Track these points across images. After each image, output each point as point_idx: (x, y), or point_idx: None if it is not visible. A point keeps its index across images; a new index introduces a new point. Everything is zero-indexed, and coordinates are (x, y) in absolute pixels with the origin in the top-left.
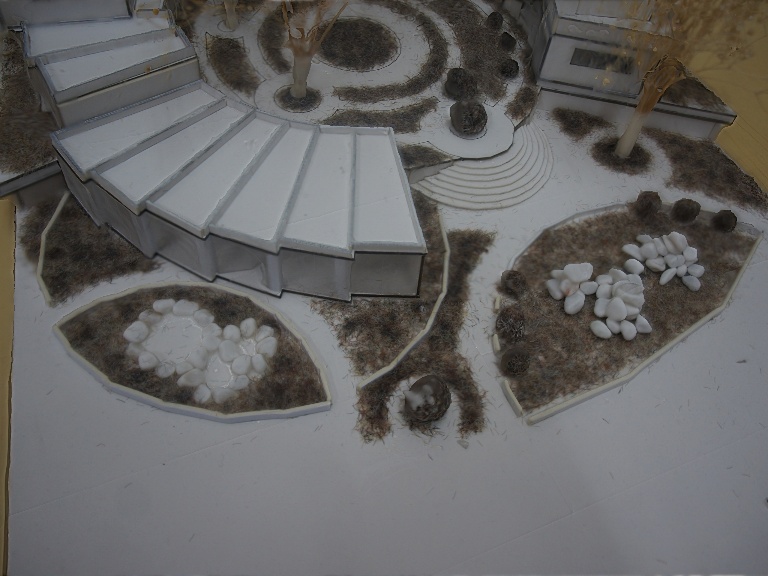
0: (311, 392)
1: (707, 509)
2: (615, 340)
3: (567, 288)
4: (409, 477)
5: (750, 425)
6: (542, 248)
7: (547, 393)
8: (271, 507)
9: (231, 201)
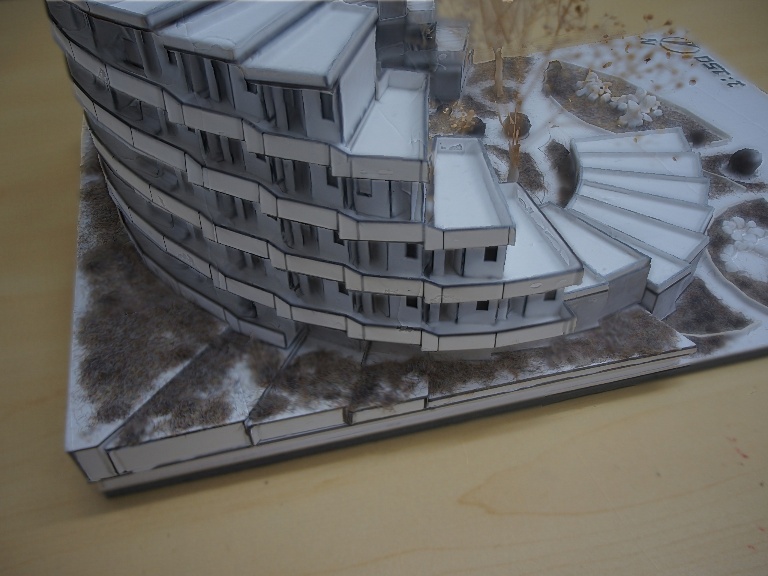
0: (758, 207)
1: (745, 102)
2: (662, 111)
3: None
4: None
5: None
6: (601, 127)
7: (708, 134)
8: None
9: None
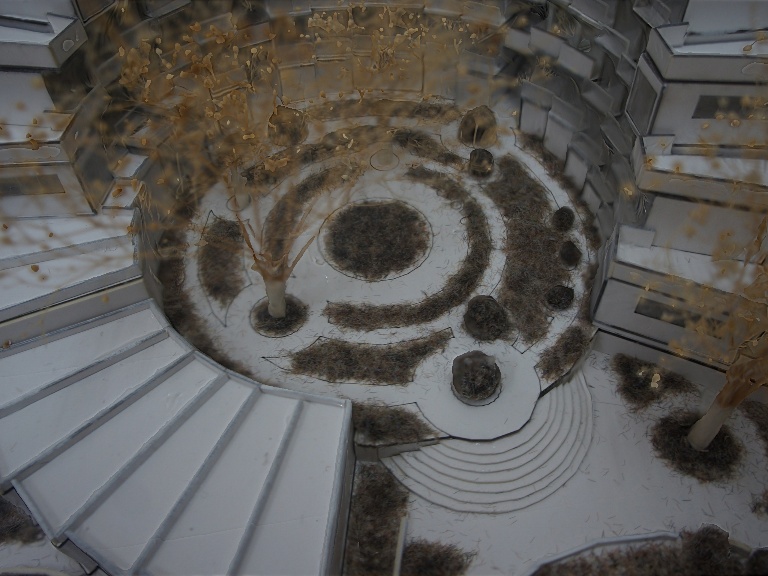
0: None
1: None
2: None
3: None
4: None
5: None
6: None
7: None
8: None
9: (113, 490)
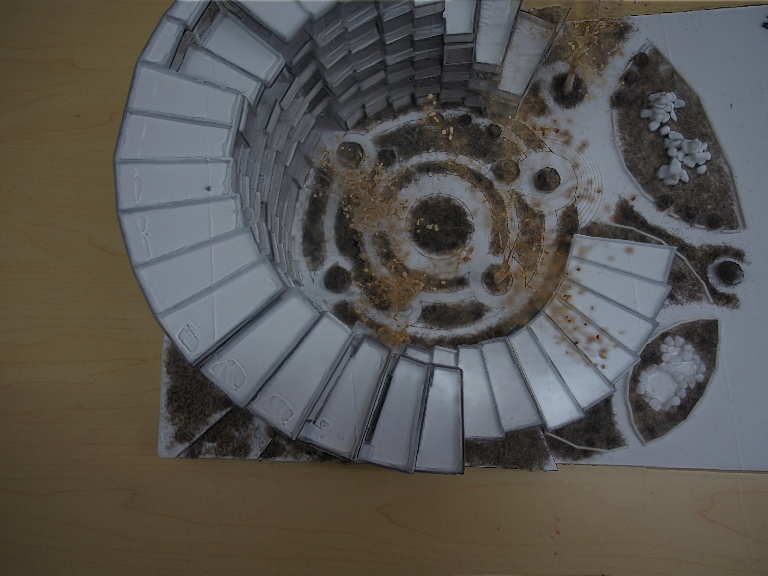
0: (708, 326)
1: None
2: (708, 165)
3: (679, 176)
4: (760, 294)
5: (766, 123)
6: (637, 174)
7: (731, 213)
8: (762, 358)
9: None
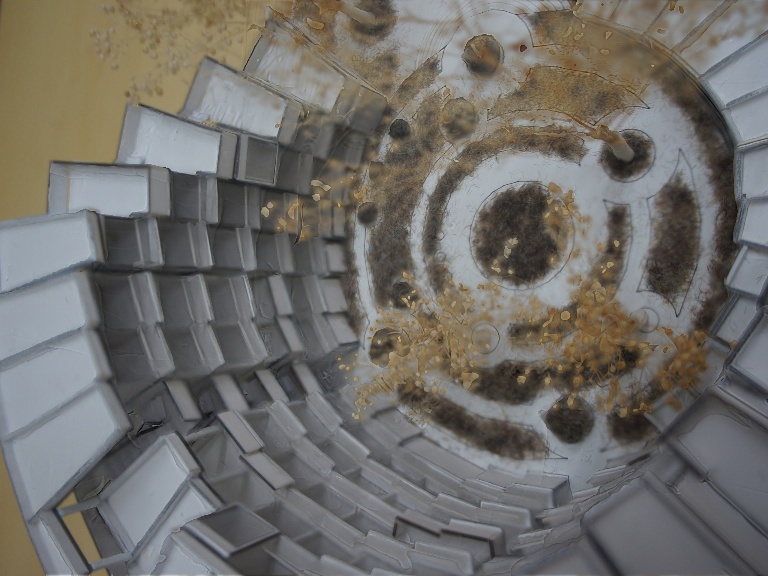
0: None
1: None
2: None
3: None
4: None
5: None
6: None
7: None
8: None
9: None
